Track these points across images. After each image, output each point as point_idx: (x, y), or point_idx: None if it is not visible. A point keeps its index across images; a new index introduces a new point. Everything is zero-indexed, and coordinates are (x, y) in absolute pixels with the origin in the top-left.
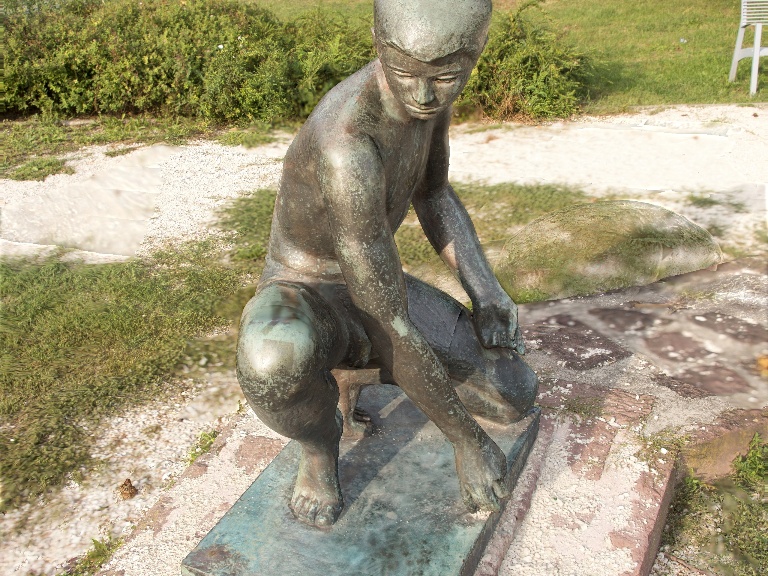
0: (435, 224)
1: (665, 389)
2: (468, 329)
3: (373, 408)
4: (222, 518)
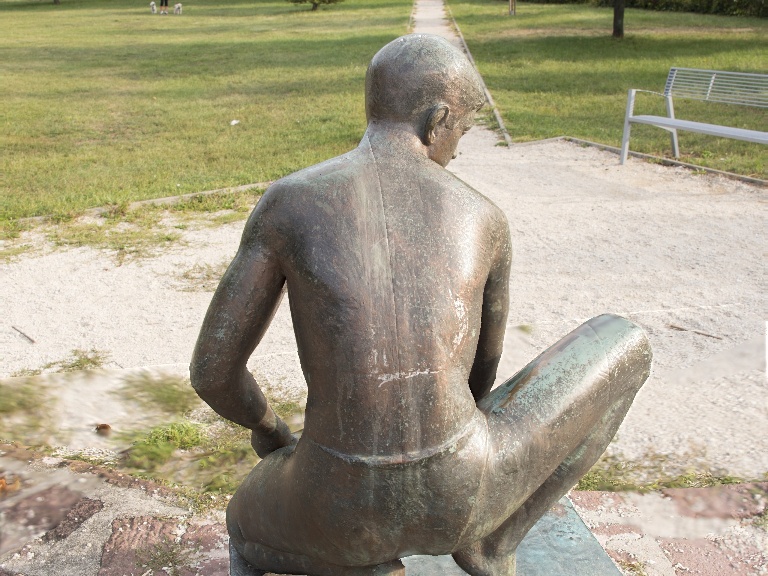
0: None
1: (92, 520)
2: None
3: None
4: None
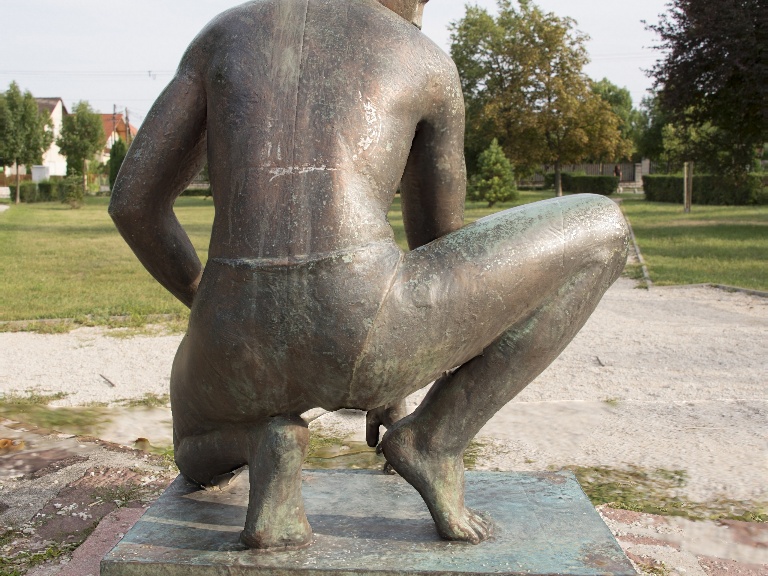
0: (187, 240)
1: (70, 467)
2: None
3: (227, 535)
4: (541, 573)
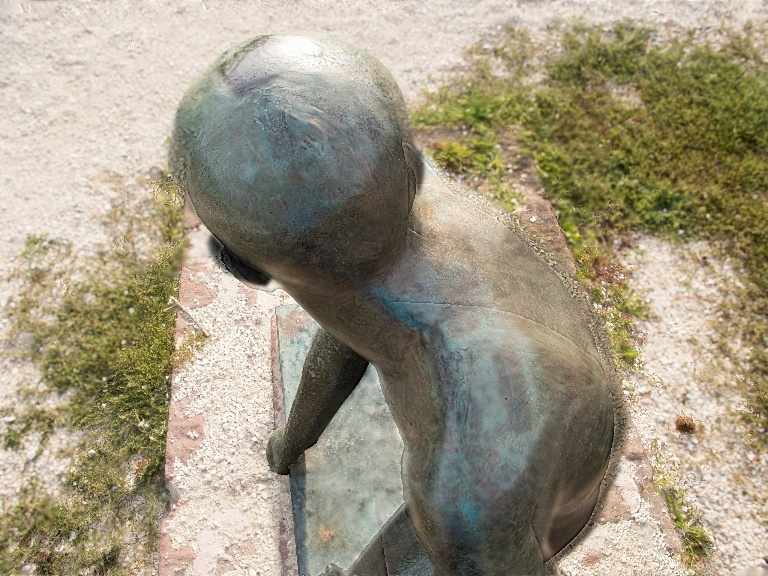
0: None
1: None
2: (373, 572)
3: None
4: None
